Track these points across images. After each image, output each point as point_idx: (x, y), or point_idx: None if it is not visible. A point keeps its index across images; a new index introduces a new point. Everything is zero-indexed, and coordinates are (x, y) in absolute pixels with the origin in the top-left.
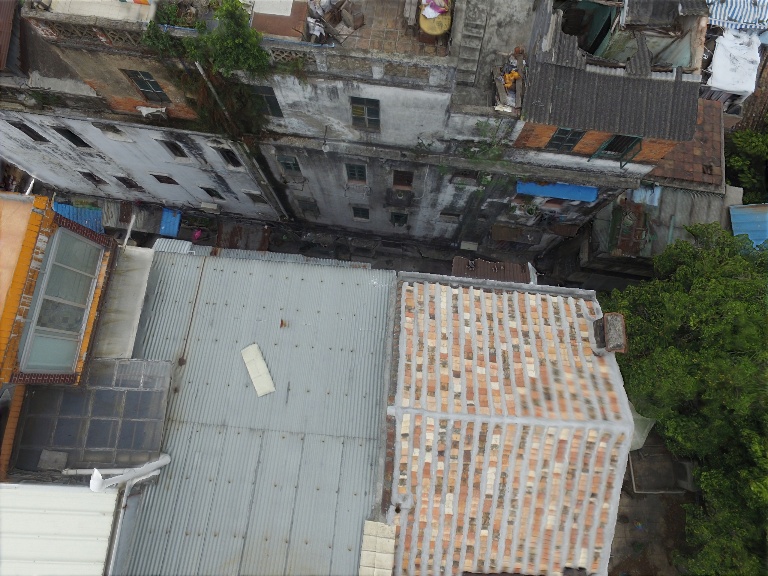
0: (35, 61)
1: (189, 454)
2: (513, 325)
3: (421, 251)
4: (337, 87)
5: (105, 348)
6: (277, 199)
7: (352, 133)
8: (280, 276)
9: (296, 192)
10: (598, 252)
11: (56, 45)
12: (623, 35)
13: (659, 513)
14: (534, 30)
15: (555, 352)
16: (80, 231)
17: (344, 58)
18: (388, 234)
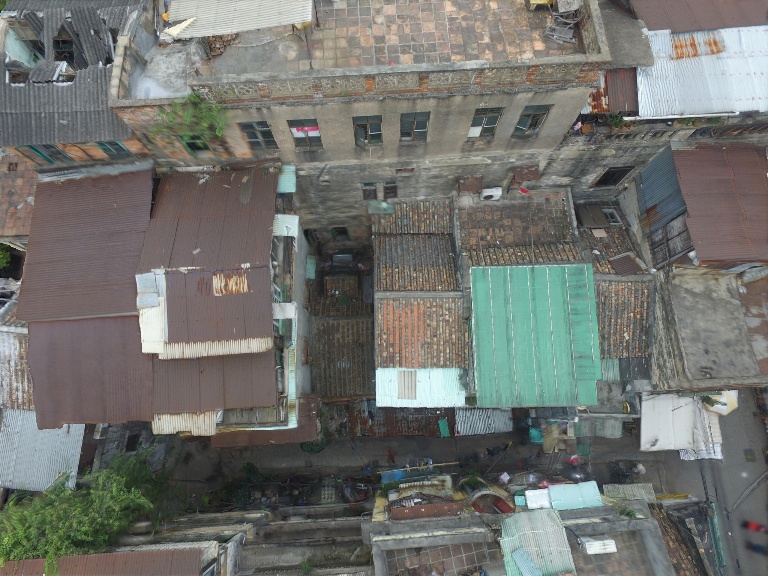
0: (604, 2)
1: None
2: None
3: None
4: None
5: None
6: None
7: None
8: None
9: None
10: None
11: None
12: None
13: None
14: None
15: None
16: None
17: None
18: None
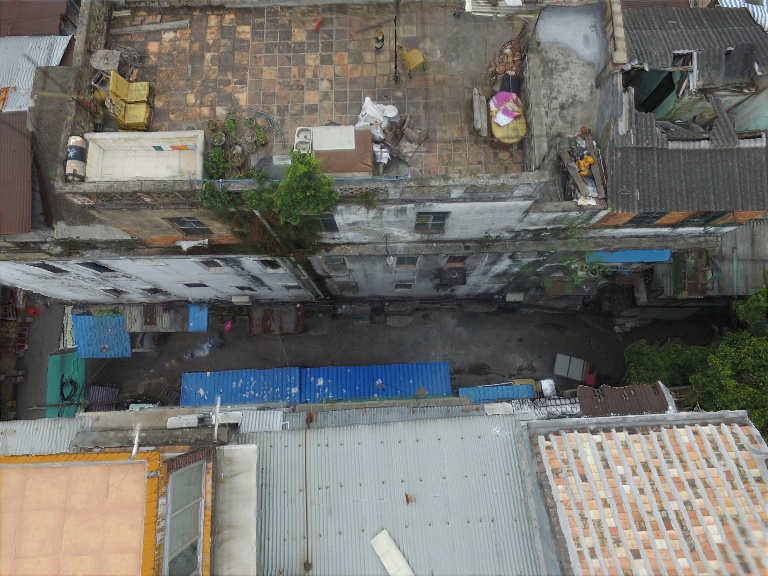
0: (58, 211)
1: None
2: (674, 474)
3: (462, 306)
4: (407, 207)
5: (225, 575)
6: (315, 286)
7: (412, 236)
8: (392, 440)
9: (337, 279)
10: (659, 293)
11: (92, 209)
12: (693, 98)
13: None
14: (601, 108)
15: (733, 504)
16: (187, 464)
17: (422, 187)
18: (429, 297)
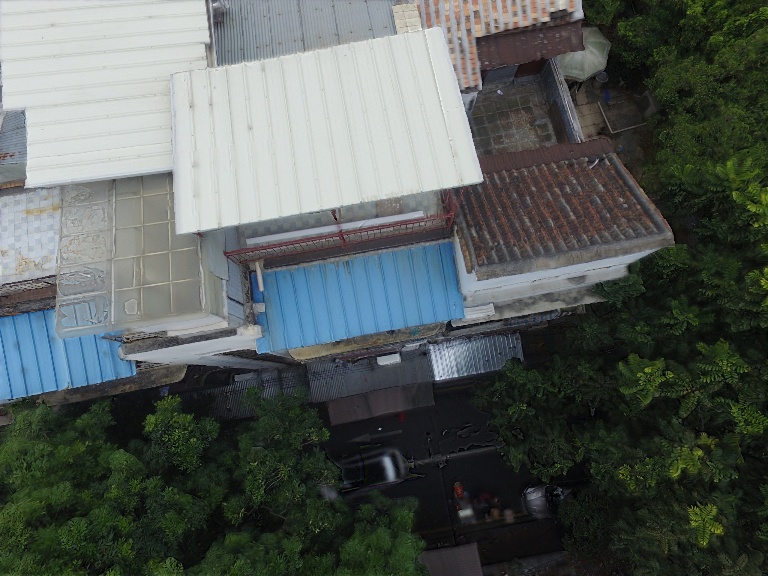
0: None
1: (242, 7)
2: None
3: None
4: None
5: None
6: None
7: None
8: None
9: None
10: None
11: None
12: None
13: (635, 144)
14: None
15: None
16: None
17: None
18: None
